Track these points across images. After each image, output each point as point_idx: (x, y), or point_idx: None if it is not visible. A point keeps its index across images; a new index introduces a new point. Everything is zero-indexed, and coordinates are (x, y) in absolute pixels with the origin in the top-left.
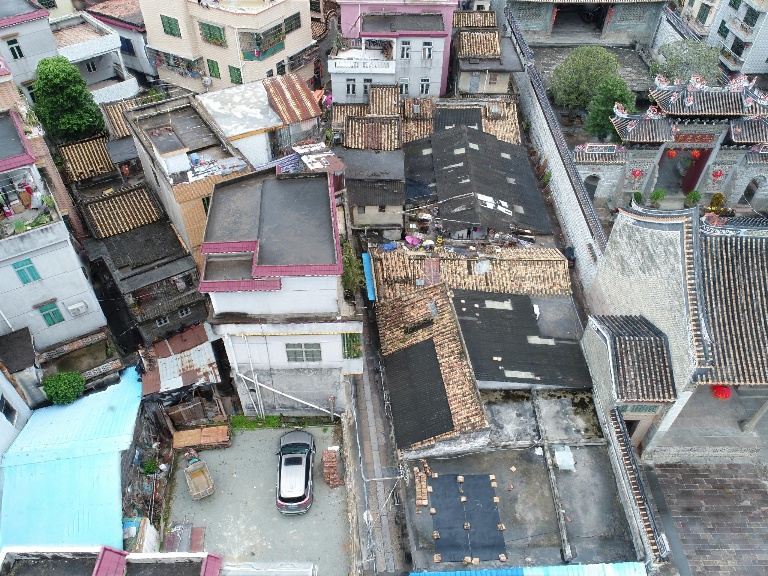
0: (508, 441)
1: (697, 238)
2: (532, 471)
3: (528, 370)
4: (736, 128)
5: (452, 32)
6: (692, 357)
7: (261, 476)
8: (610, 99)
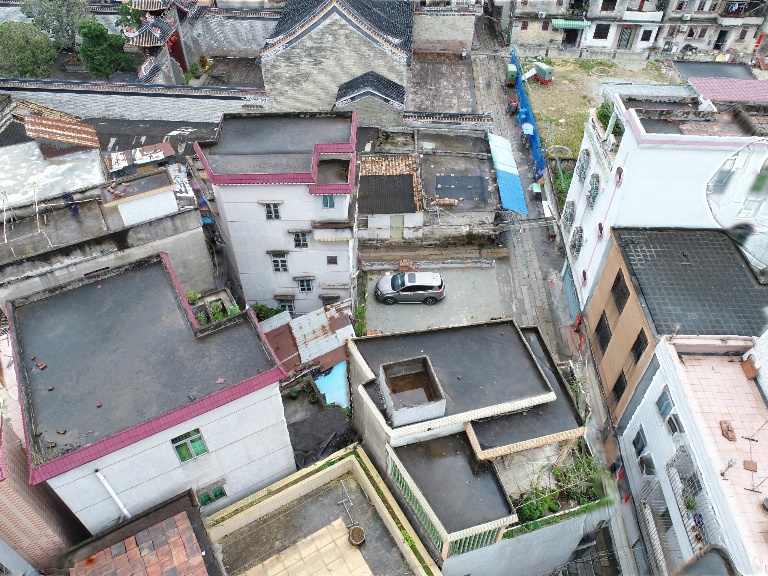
0: None
1: (349, 5)
2: (434, 160)
3: (364, 144)
4: (183, 2)
5: None
6: (399, 58)
7: (409, 316)
8: (98, 38)
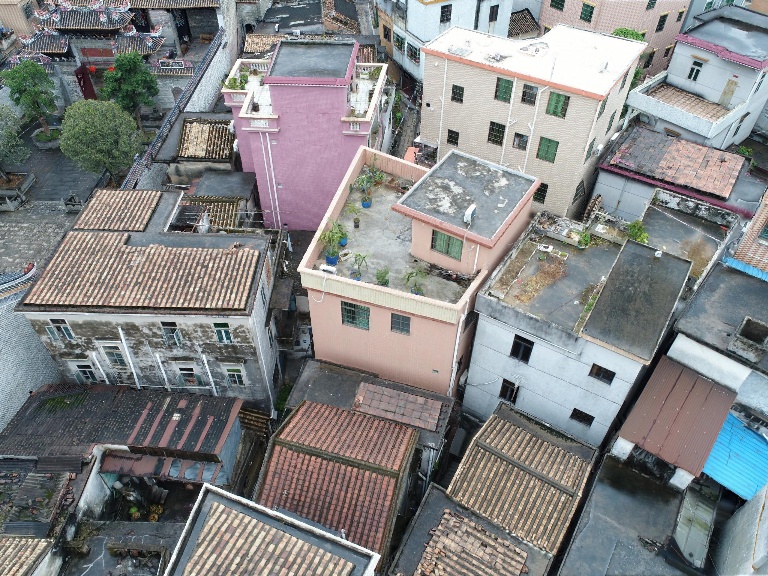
0: (312, 1)
1: None
2: None
3: None
4: None
5: (224, 186)
6: None
7: None
8: None
